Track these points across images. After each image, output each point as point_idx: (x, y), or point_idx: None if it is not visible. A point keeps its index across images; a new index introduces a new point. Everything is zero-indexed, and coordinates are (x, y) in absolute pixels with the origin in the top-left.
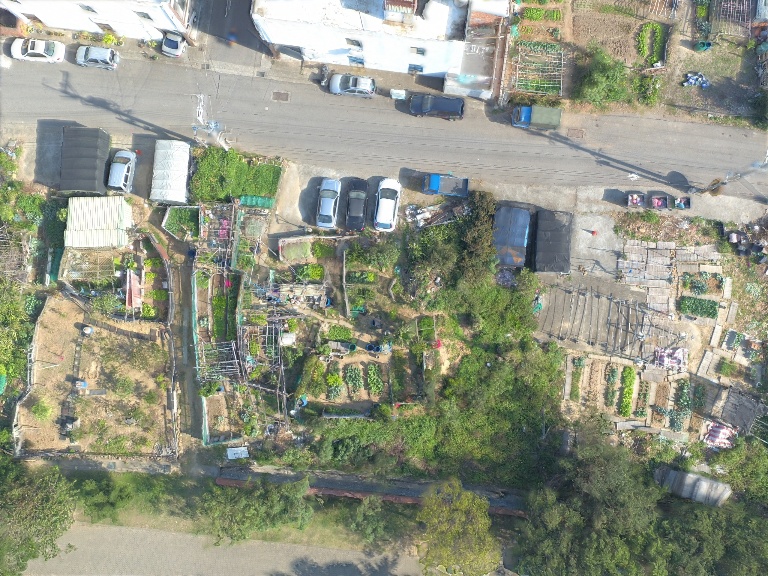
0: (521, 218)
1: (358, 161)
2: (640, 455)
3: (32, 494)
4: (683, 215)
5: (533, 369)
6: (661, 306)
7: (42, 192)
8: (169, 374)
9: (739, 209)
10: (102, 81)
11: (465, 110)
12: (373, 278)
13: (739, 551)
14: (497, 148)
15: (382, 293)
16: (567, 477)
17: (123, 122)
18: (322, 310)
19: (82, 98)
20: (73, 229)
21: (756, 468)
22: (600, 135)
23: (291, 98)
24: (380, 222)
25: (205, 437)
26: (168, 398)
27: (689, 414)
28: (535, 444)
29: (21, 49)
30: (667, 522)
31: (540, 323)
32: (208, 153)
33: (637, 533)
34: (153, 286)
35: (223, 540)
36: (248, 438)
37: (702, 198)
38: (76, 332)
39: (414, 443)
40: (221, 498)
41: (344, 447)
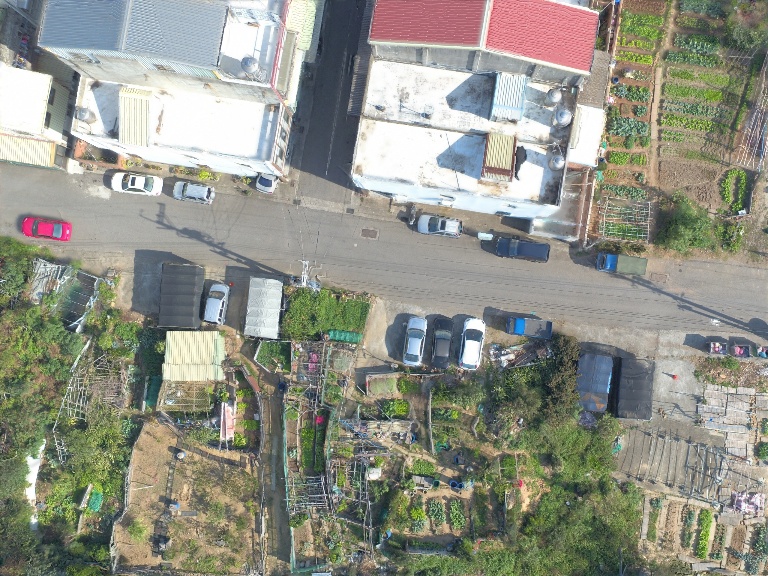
0: (605, 365)
1: (444, 299)
2: None
3: None
4: (764, 362)
5: (612, 511)
6: (739, 451)
7: (139, 320)
8: (257, 499)
9: None
10: (197, 214)
11: (550, 252)
12: (457, 416)
13: None
14: (580, 290)
15: (465, 430)
16: None
17: (217, 254)
18: (406, 444)
19: (178, 230)
20: (171, 363)
21: None
22: (683, 280)
23: (380, 235)
24: (466, 363)
25: (292, 564)
26: (256, 522)
27: (764, 558)
28: None
29: (122, 183)
30: None
31: (619, 463)
32: (301, 293)
33: None
34: (244, 416)
35: None
36: (332, 564)
37: None
38: (169, 455)
39: None
40: None
41: None
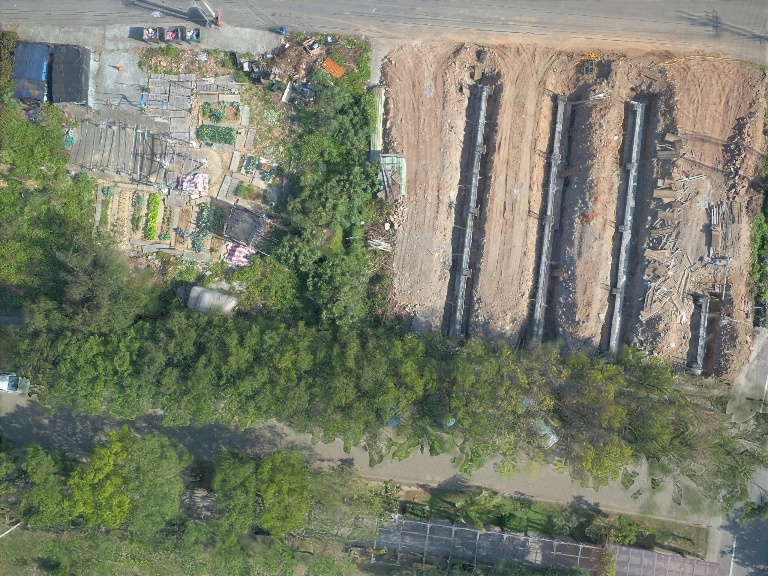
0: (38, 53)
1: None
2: (163, 275)
3: None
4: (203, 48)
5: (57, 196)
6: (183, 135)
7: None
8: None
9: (255, 40)
10: None
11: None
12: None
13: (206, 345)
14: None
15: None
16: (67, 288)
17: None
18: None
19: None
20: None
21: (270, 283)
22: None
23: None
24: None
25: None
26: None
27: (209, 235)
28: (67, 268)
29: None
30: (149, 323)
31: (73, 156)
32: None
33: (112, 331)
34: None
35: None
36: None
37: (220, 31)
38: None
39: None
40: None
41: None
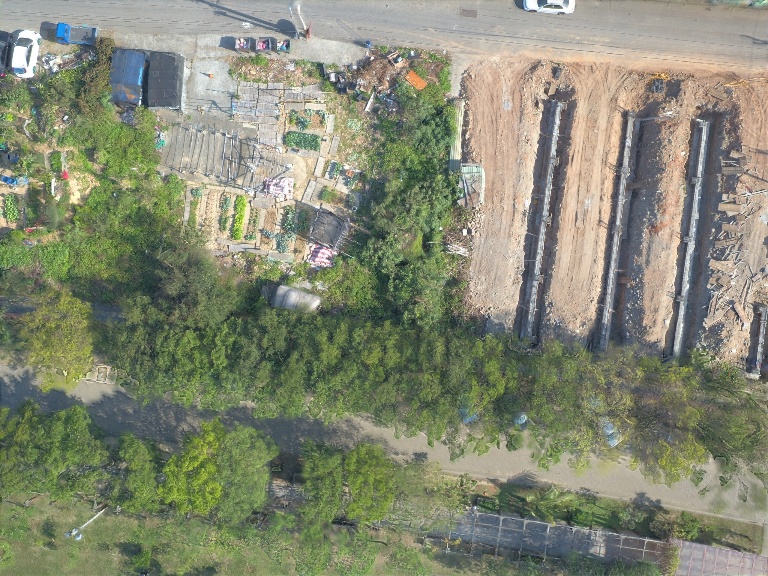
0: (135, 59)
1: (4, 16)
2: (249, 274)
3: None
4: (291, 58)
5: (149, 196)
6: (270, 140)
7: None
8: None
9: (341, 52)
10: None
11: None
12: (12, 119)
13: (297, 341)
14: (127, 2)
15: (21, 133)
16: (161, 284)
17: None
18: None
19: None
20: None
21: (351, 284)
22: None
23: None
24: (14, 67)
25: None
26: None
27: (293, 237)
28: (156, 265)
29: None
30: (241, 319)
31: (163, 158)
32: None
33: (207, 326)
34: None
35: None
36: None
37: (308, 43)
38: None
39: (49, 266)
40: None
41: None
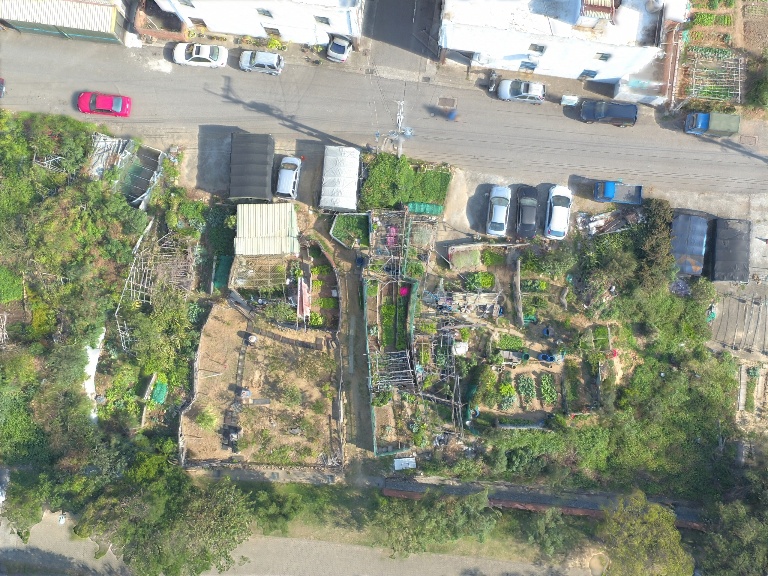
0: (699, 226)
1: (526, 168)
2: None
3: (211, 506)
4: None
5: (710, 379)
6: None
7: (205, 199)
8: (334, 383)
9: None
10: (265, 86)
11: None
12: (545, 287)
13: None
14: (668, 155)
15: (553, 302)
16: (754, 490)
17: (286, 128)
18: (492, 319)
19: (244, 103)
20: (243, 236)
21: None
22: None
23: (457, 104)
24: (554, 230)
25: (375, 448)
26: (333, 408)
27: None
28: (710, 455)
29: (185, 54)
30: None
31: (713, 333)
32: (380, 160)
33: None
34: (320, 294)
35: (390, 552)
36: (416, 448)
37: None
38: (239, 340)
39: (587, 454)
40: (398, 510)
41: (518, 458)
